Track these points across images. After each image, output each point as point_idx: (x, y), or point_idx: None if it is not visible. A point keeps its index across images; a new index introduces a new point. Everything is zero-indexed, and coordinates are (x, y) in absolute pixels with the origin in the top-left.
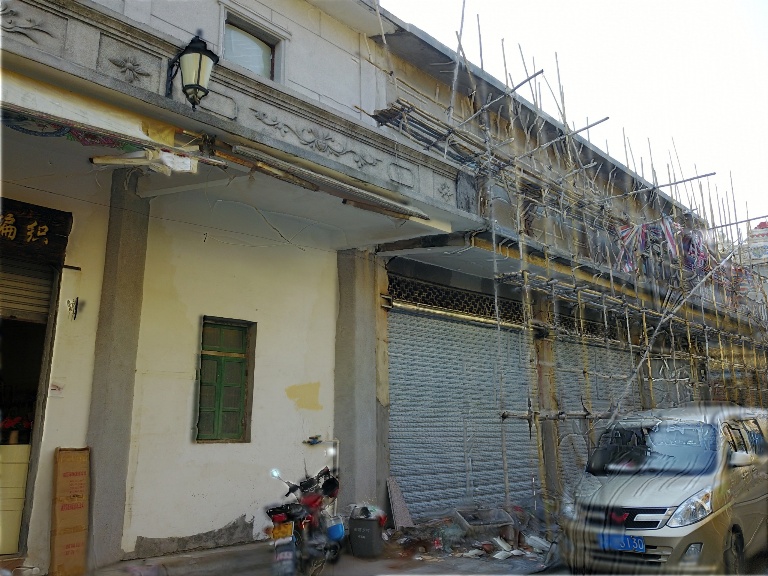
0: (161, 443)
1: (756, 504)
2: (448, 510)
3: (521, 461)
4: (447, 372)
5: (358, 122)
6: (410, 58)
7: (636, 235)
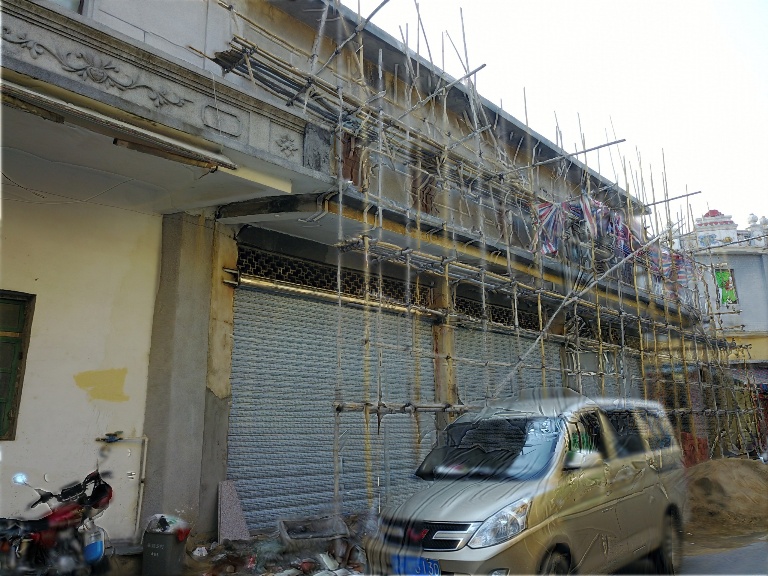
0: None
1: (586, 517)
2: (306, 518)
3: (408, 461)
4: (315, 360)
5: (156, 52)
6: (278, 2)
7: (555, 214)
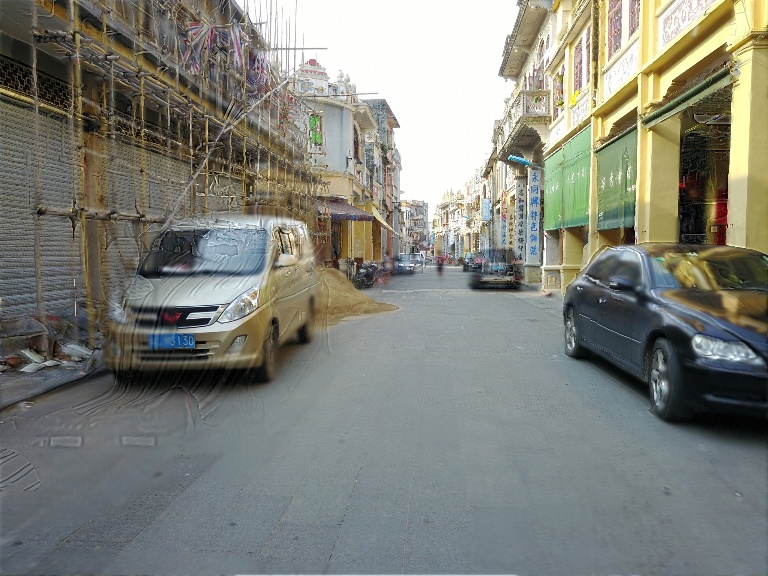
0: None
1: (293, 299)
2: None
3: (58, 268)
4: None
5: None
6: None
7: (205, 36)
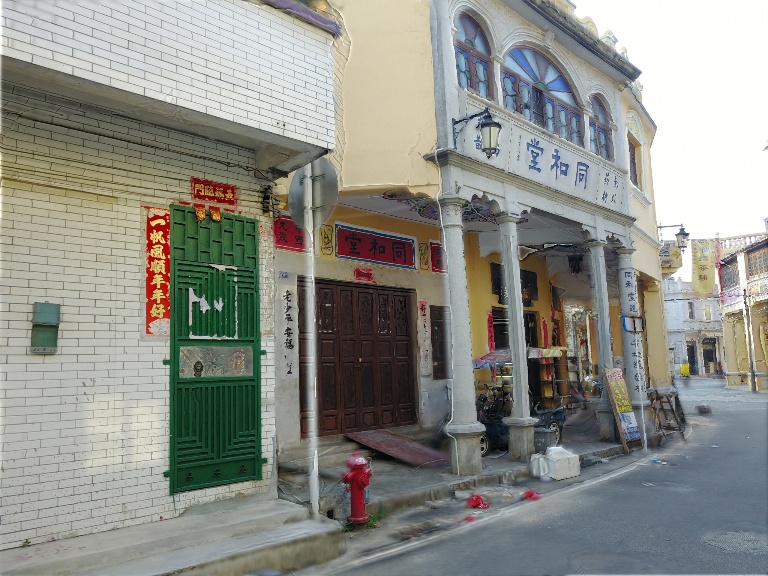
0: (722, 362)
1: None
2: None
3: None
4: None
5: None
6: None
7: None
